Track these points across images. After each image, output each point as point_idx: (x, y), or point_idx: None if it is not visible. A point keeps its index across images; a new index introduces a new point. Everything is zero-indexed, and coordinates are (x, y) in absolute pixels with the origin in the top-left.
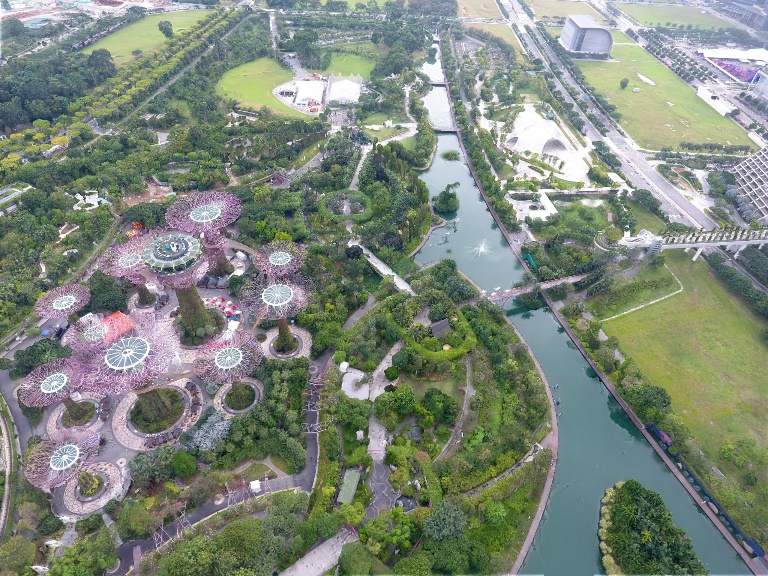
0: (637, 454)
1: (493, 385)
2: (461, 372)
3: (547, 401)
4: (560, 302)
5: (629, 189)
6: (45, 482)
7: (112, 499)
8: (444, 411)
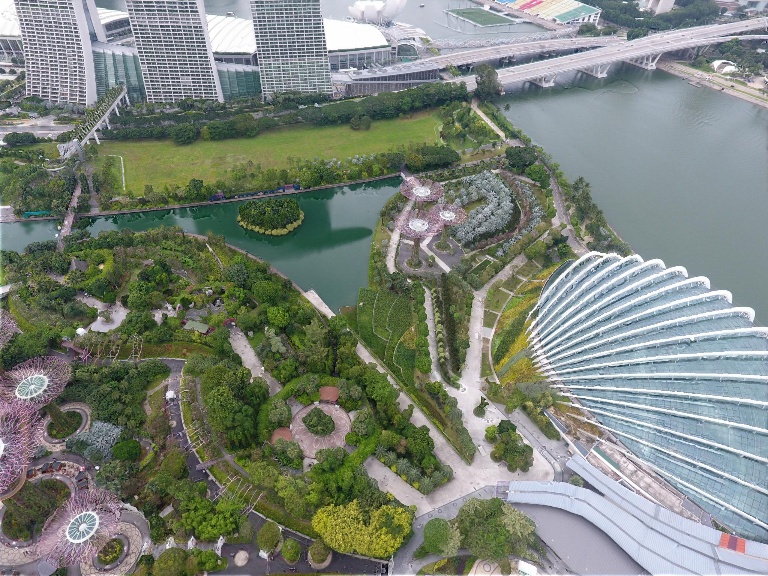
0: (222, 217)
1: (151, 248)
2: (130, 263)
3: (177, 226)
4: (93, 209)
5: None
6: (108, 533)
7: None
8: (162, 268)
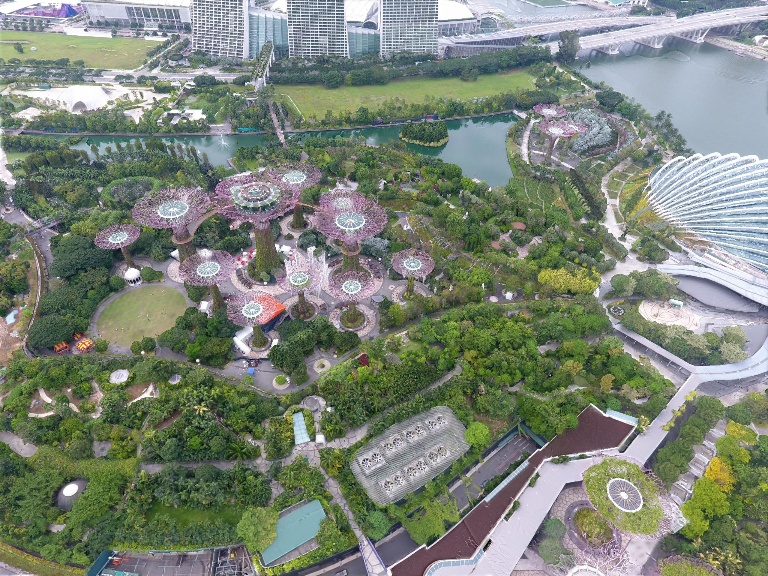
0: (378, 139)
1: None
2: None
3: None
4: (286, 128)
5: (188, 83)
6: None
7: (421, 277)
8: None
